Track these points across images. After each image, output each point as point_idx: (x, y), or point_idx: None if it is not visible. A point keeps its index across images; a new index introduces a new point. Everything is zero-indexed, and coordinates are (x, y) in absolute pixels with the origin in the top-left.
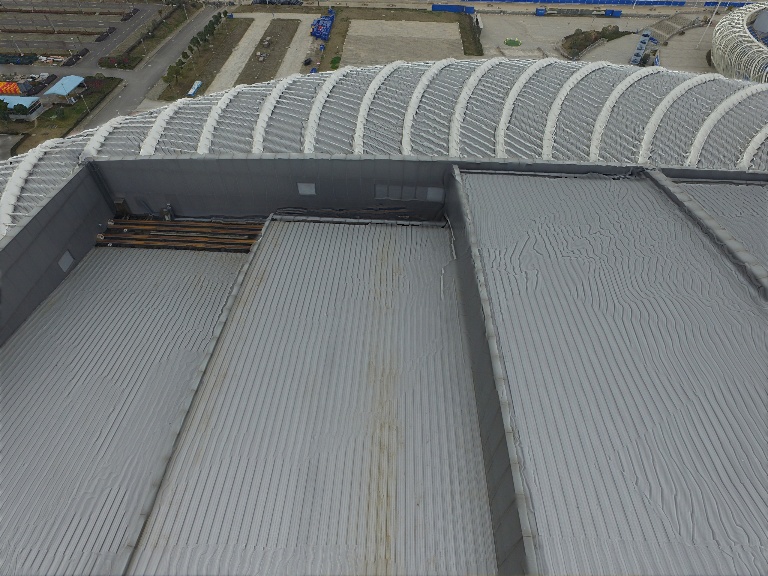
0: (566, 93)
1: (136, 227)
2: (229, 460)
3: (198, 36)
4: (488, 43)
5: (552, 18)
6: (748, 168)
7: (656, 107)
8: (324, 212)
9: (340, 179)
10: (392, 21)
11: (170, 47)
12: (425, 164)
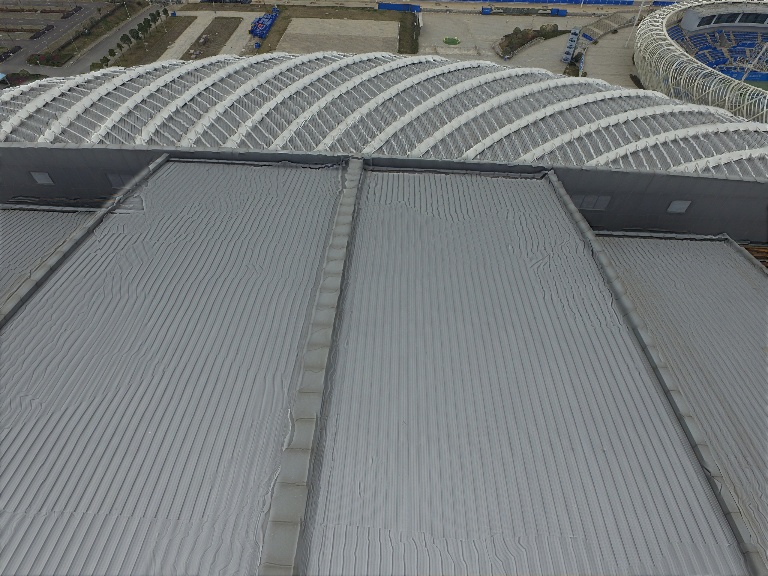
0: (353, 86)
1: None
2: None
3: (130, 34)
4: (427, 41)
5: (497, 17)
6: (473, 158)
7: (428, 99)
8: (55, 201)
9: (69, 168)
10: (333, 19)
11: (104, 45)
12: (140, 153)
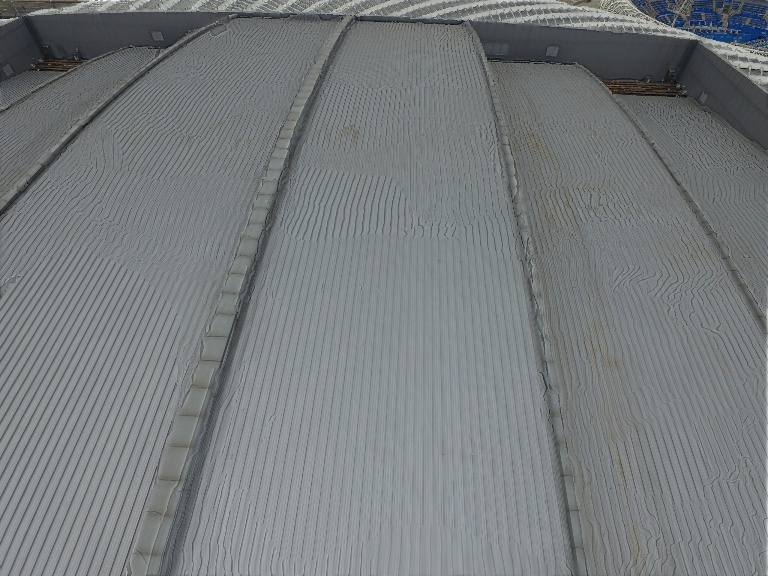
0: None
1: (56, 63)
2: None
3: None
4: None
5: None
6: None
7: None
8: None
9: (175, 27)
10: None
11: None
12: (221, 14)
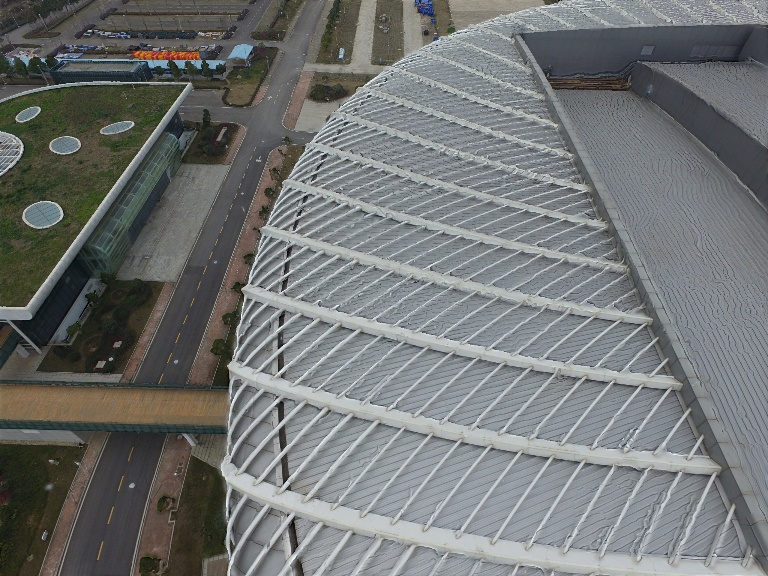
0: None
1: None
2: (762, 116)
3: None
4: None
5: None
6: None
7: None
8: None
9: (674, 41)
10: None
11: (303, 23)
12: (735, 27)
